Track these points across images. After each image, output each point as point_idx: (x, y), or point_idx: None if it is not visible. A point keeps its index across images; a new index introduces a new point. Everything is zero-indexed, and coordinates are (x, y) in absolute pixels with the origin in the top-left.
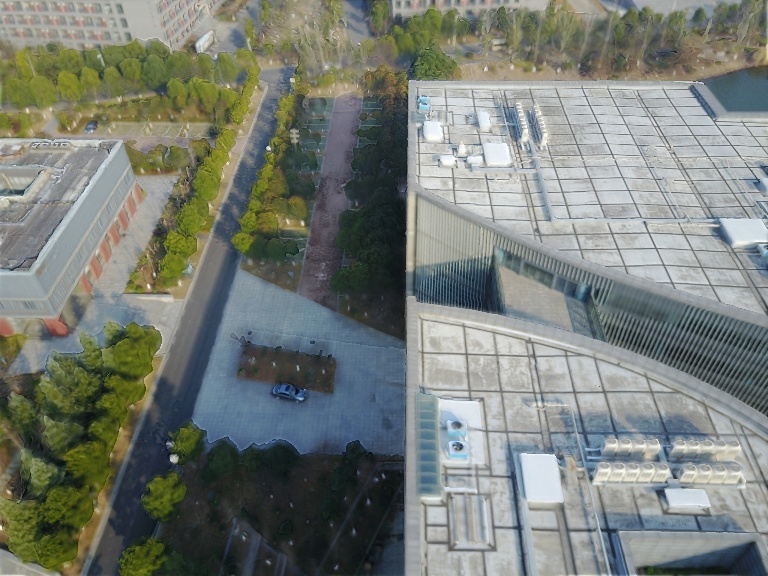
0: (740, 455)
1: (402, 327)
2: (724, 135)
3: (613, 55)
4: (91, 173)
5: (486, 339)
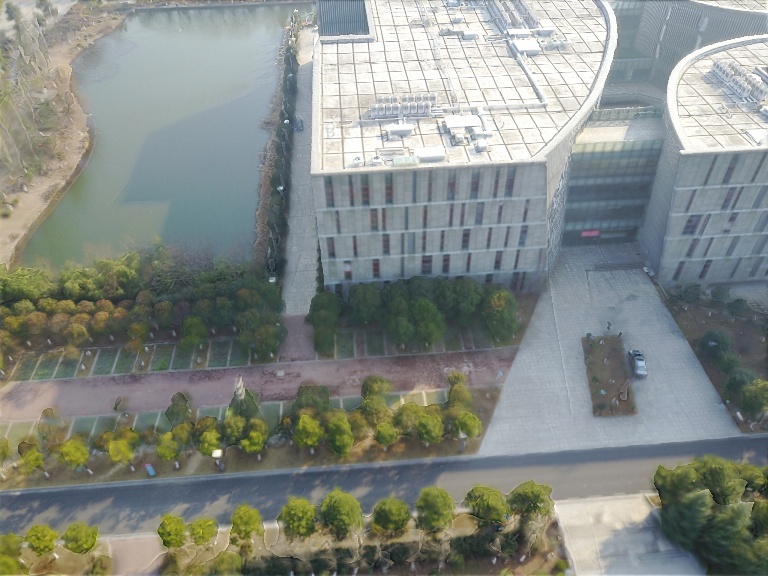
0: (709, 69)
1: (525, 295)
2: (399, 41)
3: (31, 140)
4: None
5: (691, 129)
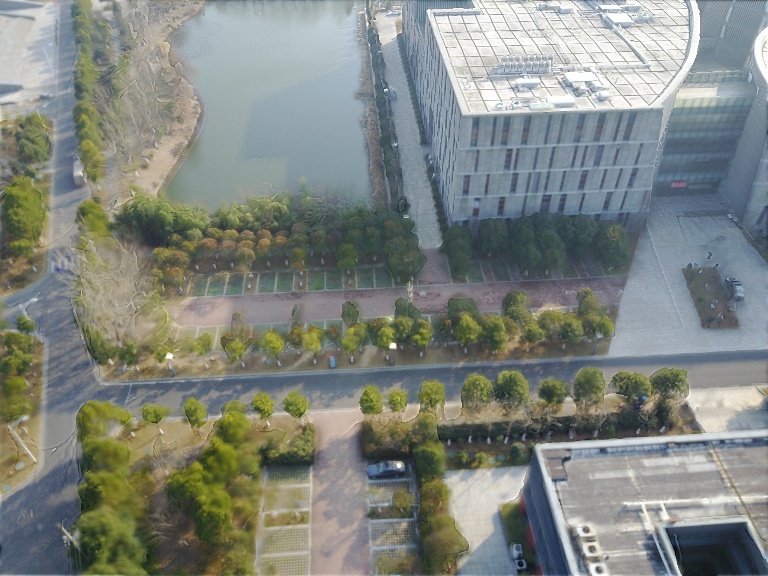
0: None
1: None
2: (503, 14)
3: None
4: (631, 463)
5: None
